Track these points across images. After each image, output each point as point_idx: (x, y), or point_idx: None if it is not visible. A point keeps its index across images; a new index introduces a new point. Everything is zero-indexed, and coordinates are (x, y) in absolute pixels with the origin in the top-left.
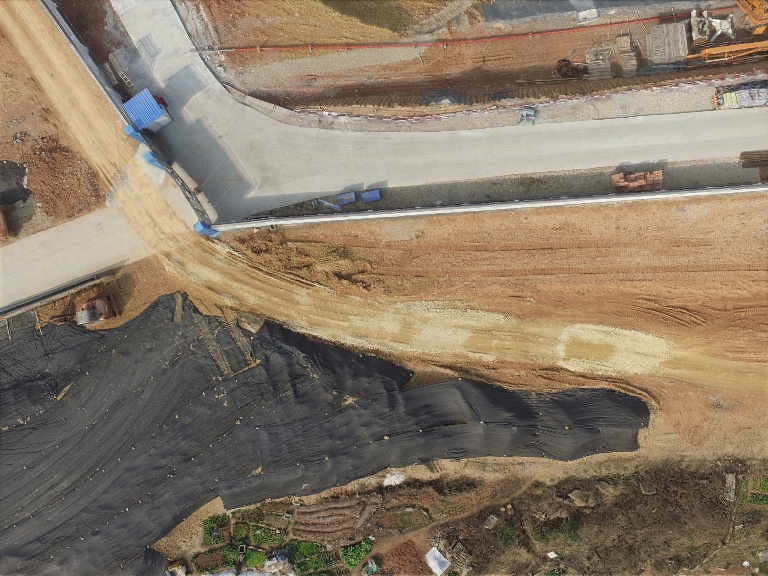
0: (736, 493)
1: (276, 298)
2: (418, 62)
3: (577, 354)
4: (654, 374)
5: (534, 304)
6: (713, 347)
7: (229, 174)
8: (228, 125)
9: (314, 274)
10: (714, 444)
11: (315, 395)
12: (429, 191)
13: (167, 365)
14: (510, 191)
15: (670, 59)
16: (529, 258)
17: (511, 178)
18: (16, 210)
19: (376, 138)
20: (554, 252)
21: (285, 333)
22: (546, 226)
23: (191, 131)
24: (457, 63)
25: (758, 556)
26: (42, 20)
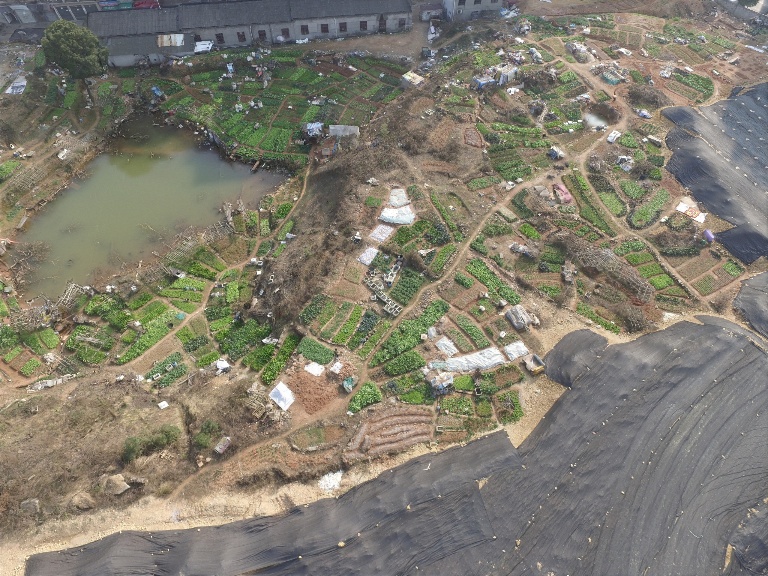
0: None
1: None
2: None
3: None
4: None
5: None
6: None
7: None
8: None
9: None
10: None
11: None
12: None
13: None
14: None
15: None
16: None
17: None
18: None
19: None
20: None
21: None
22: None
23: None
24: None
25: None
26: None
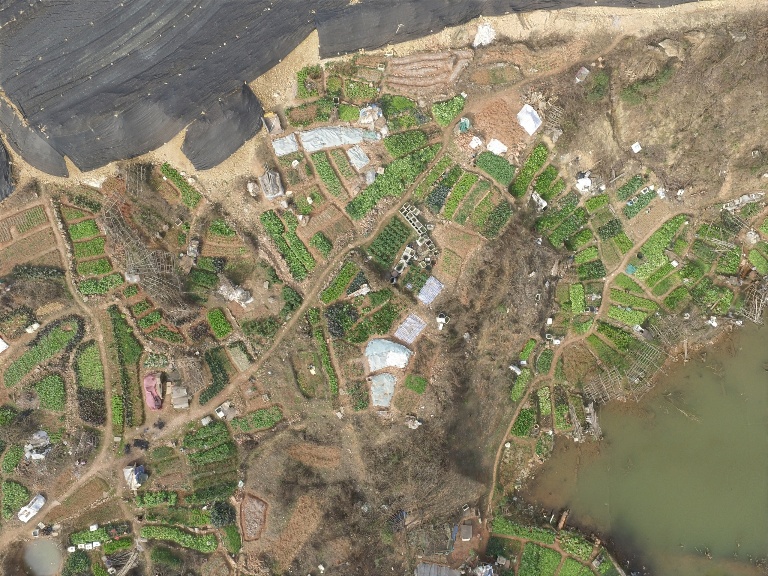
0: None
1: None
2: None
3: None
4: None
5: None
6: None
7: None
8: None
9: None
10: None
11: None
12: None
13: None
14: None
15: None
16: None
17: None
18: None
19: None
20: None
21: None
22: None
23: None
24: None
25: None
26: None
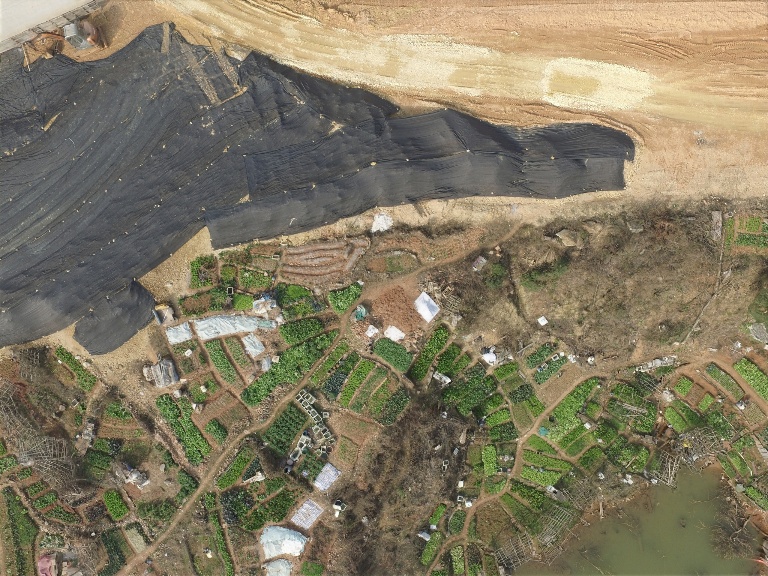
0: (723, 233)
1: (263, 30)
2: None
3: (561, 88)
4: (638, 110)
5: (518, 38)
6: (695, 81)
7: None
8: None
9: (300, 5)
10: (699, 182)
11: (302, 122)
12: None
13: (154, 96)
14: None
15: None
16: None
17: None
18: None
19: None
20: None
21: (272, 63)
22: None
23: None
24: None
25: (749, 329)
26: None
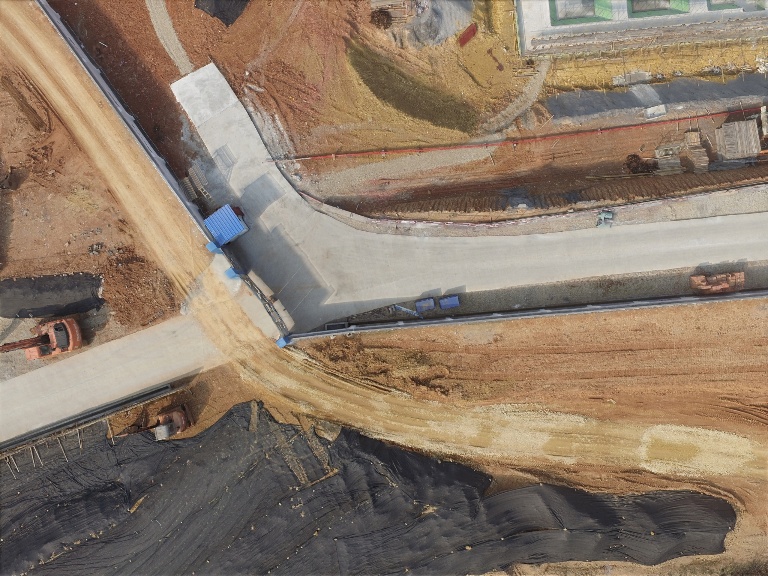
0: None
1: (352, 404)
2: (489, 161)
3: (659, 455)
4: (738, 474)
5: (614, 405)
6: None
7: (306, 282)
8: (305, 233)
9: (391, 379)
10: None
11: (394, 505)
12: (507, 295)
13: (242, 475)
14: (589, 293)
15: (743, 155)
16: (609, 360)
17: (590, 280)
18: (89, 318)
19: (453, 243)
20: (634, 353)
21: (362, 440)
22: (625, 327)
23: (267, 240)
24: (527, 161)
25: None
26: (119, 133)
